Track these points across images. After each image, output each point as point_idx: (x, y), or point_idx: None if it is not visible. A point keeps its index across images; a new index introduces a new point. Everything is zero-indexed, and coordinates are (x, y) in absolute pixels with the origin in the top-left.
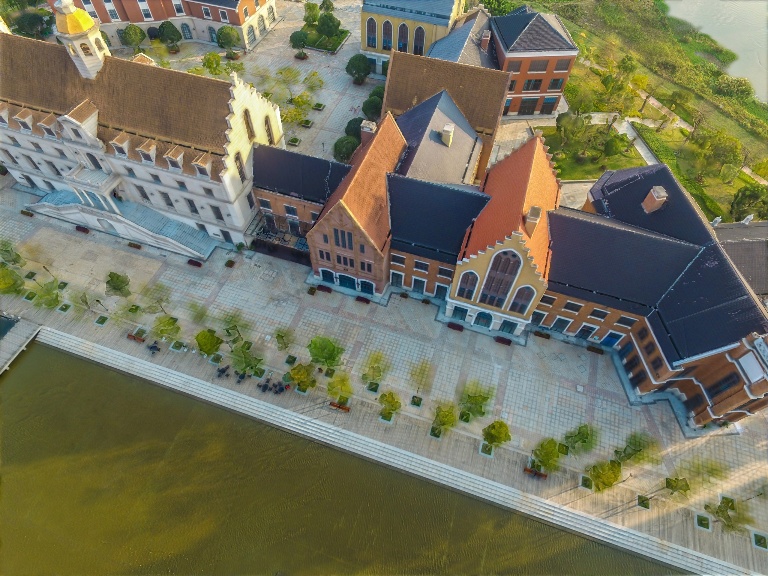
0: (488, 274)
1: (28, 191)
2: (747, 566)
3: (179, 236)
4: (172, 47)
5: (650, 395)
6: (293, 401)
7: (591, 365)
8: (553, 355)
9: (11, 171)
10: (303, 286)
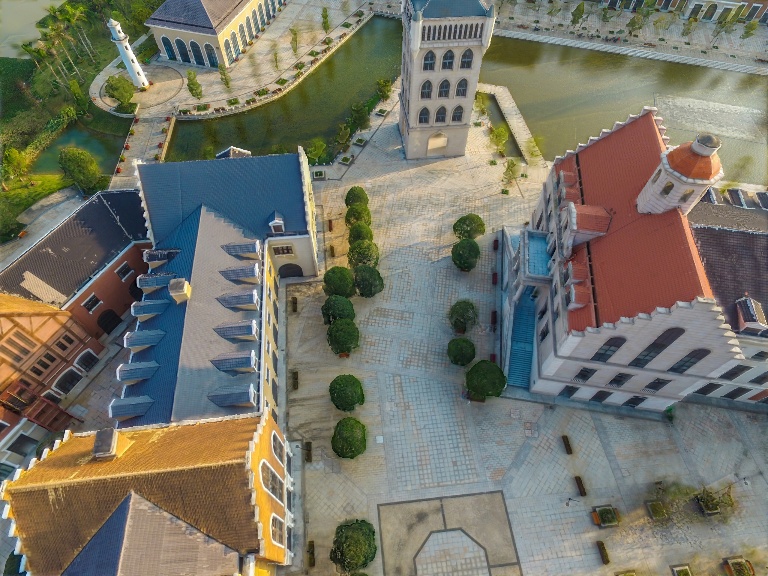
0: None
1: None
2: None
3: None
4: None
5: None
6: (624, 45)
7: None
8: None
9: None
10: (598, 9)
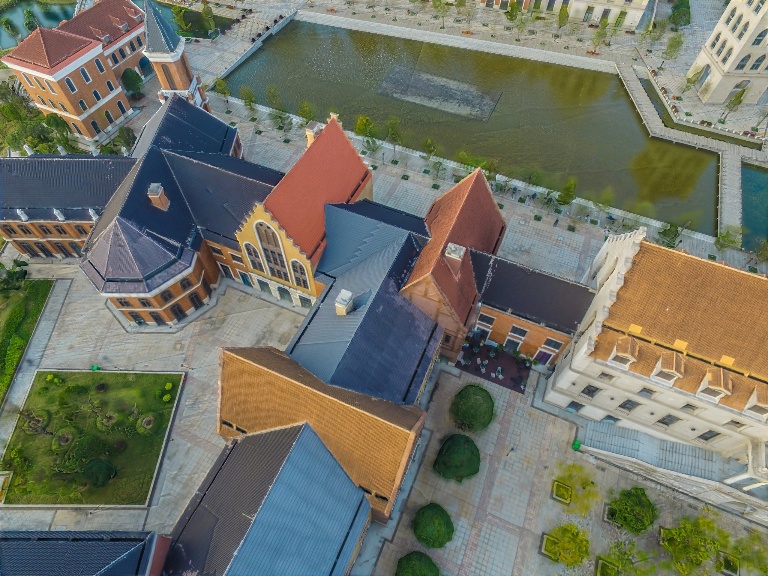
0: None
1: None
2: (244, 106)
3: None
4: None
5: None
6: None
7: None
8: None
9: None
10: None
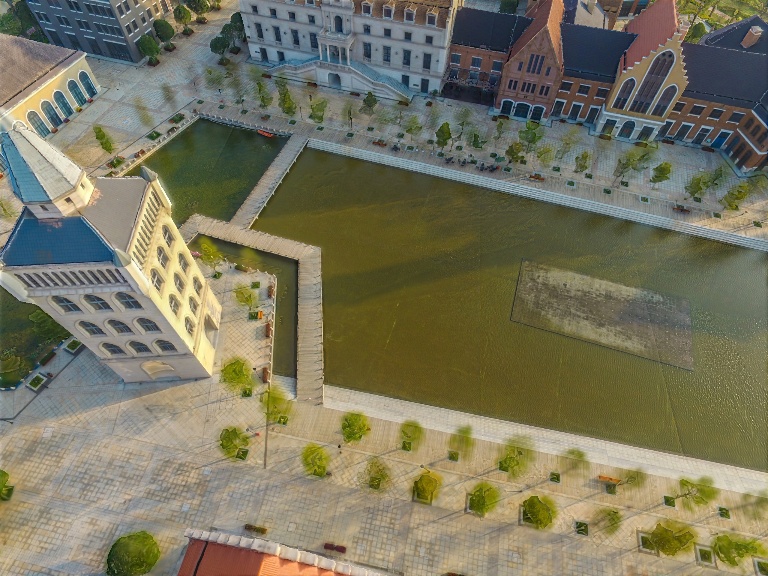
0: (644, 79)
1: (259, 64)
2: None
3: (390, 85)
4: None
5: (752, 172)
6: (503, 176)
7: (706, 158)
8: (678, 153)
9: (251, 46)
10: (487, 116)
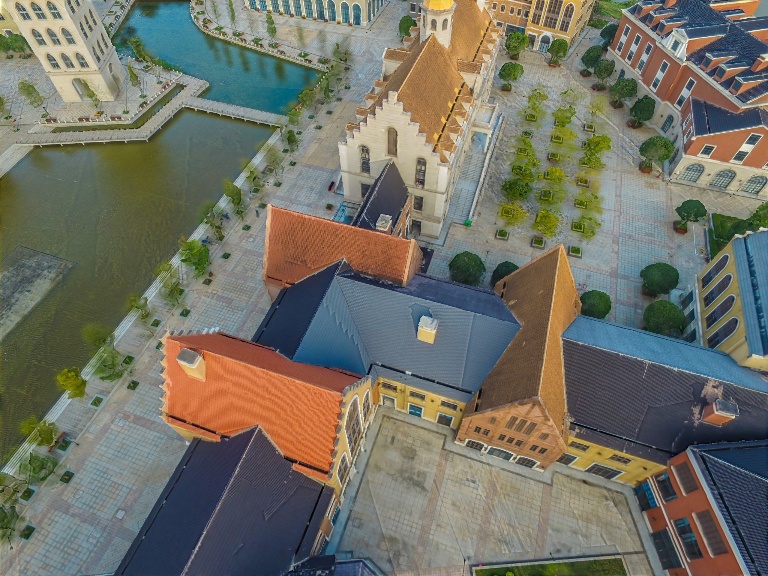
0: None
1: None
2: None
3: None
4: (634, 120)
5: None
6: None
7: None
8: None
9: None
10: None
